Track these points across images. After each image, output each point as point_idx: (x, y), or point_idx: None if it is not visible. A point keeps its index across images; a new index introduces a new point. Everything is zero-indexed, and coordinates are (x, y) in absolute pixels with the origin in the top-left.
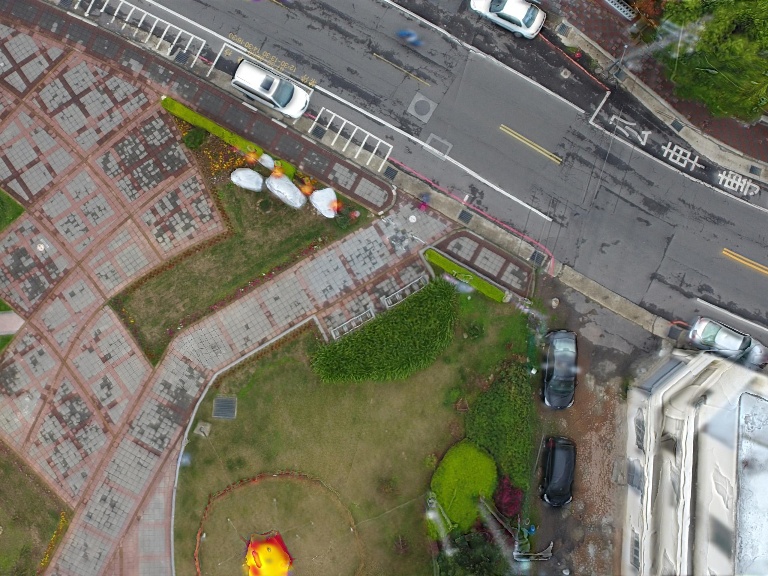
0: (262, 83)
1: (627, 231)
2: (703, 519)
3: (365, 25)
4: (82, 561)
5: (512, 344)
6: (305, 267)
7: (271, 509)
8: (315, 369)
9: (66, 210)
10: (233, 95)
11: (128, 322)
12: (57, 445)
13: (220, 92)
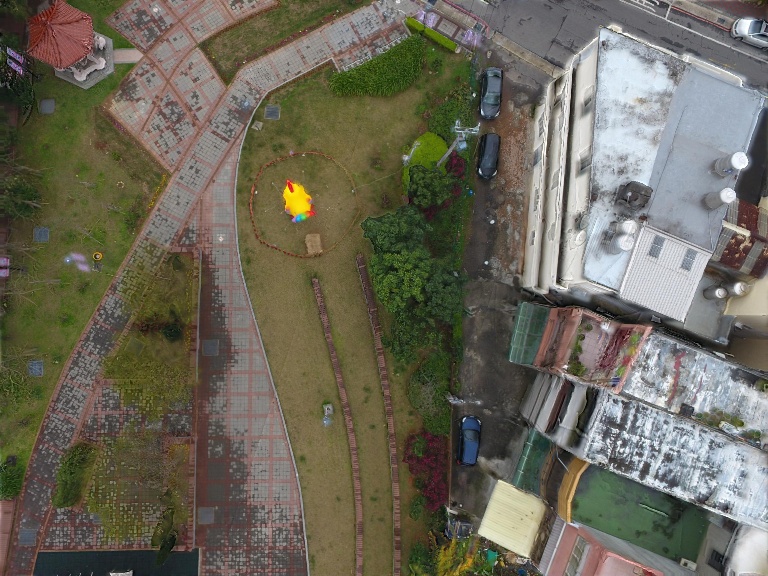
0: None
1: (537, 12)
2: (577, 131)
3: None
4: (175, 207)
5: (460, 78)
6: (327, 29)
7: (300, 178)
8: (332, 87)
9: None
10: None
11: (211, 58)
12: (162, 133)
13: None
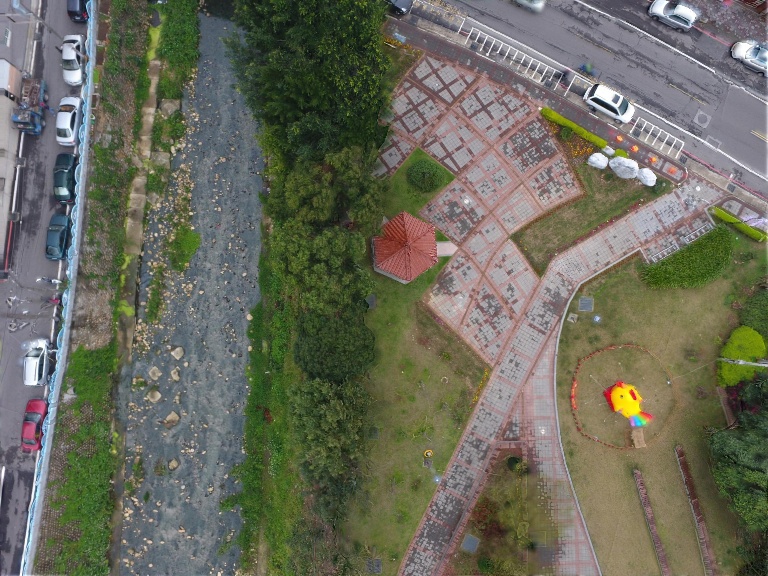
0: (613, 99)
1: None
2: None
3: (664, 66)
4: (498, 401)
5: (765, 268)
6: (632, 217)
7: (617, 369)
8: (647, 280)
9: (481, 178)
10: (582, 108)
11: (523, 250)
12: (480, 327)
13: (574, 106)
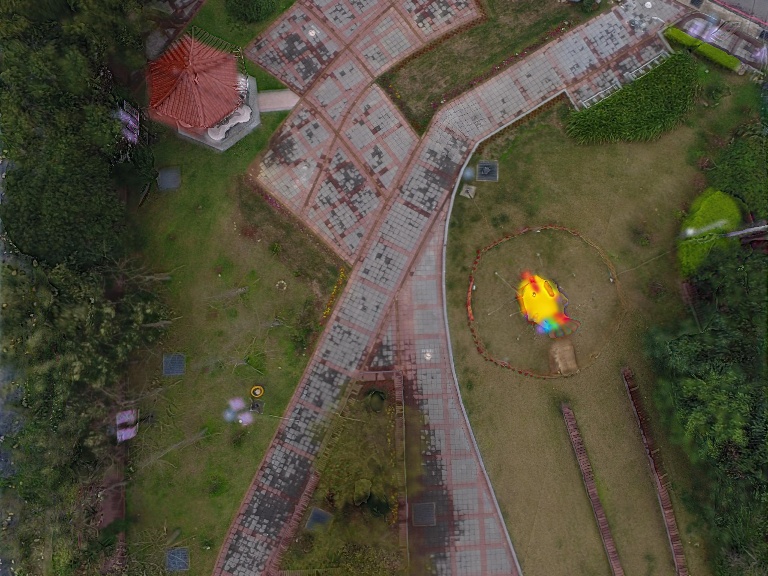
0: None
1: None
2: None
3: None
4: (360, 314)
5: (750, 111)
6: (553, 48)
7: (534, 263)
8: (574, 132)
9: (333, 0)
10: None
11: (395, 97)
12: (333, 209)
13: None
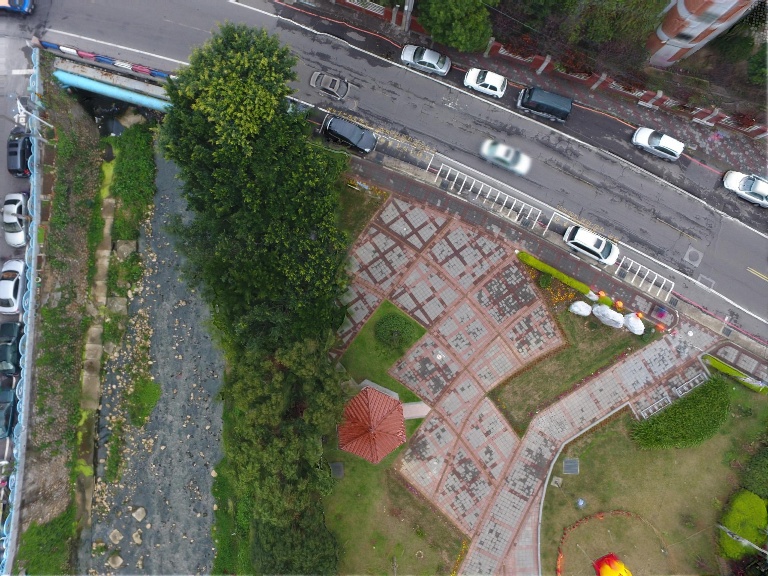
0: (595, 244)
1: None
2: None
3: (650, 199)
4: (478, 575)
5: (766, 420)
6: (619, 368)
7: (606, 537)
8: (636, 441)
9: (455, 331)
10: (562, 248)
11: (502, 408)
12: (457, 495)
13: (554, 246)
